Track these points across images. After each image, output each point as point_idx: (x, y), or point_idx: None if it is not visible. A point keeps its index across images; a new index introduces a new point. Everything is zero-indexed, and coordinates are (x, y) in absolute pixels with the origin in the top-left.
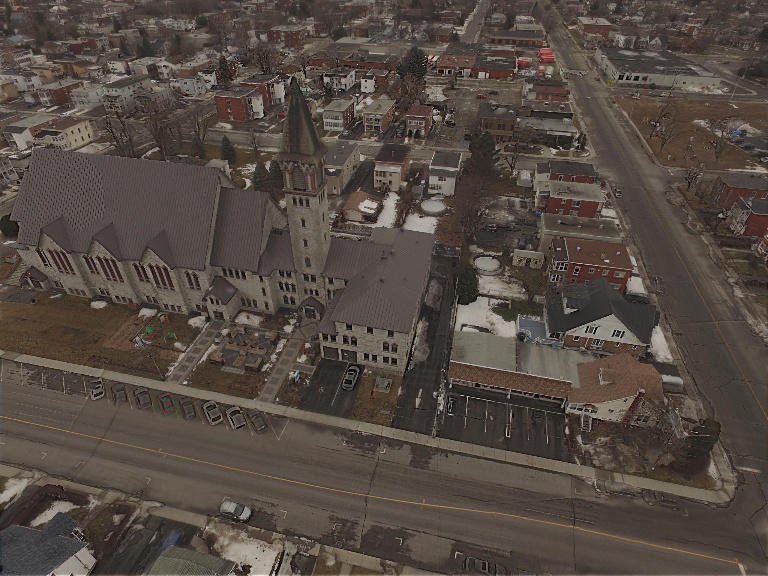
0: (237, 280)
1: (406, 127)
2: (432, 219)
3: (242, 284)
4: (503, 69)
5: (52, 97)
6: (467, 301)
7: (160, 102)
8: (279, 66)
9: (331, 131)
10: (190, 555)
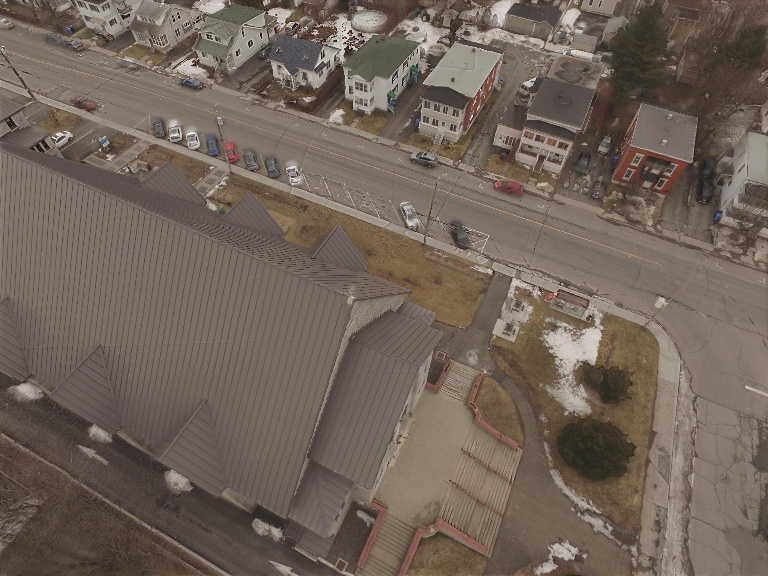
0: None
1: None
2: None
3: None
4: None
5: None
6: None
7: None
8: None
9: None
10: (215, 51)
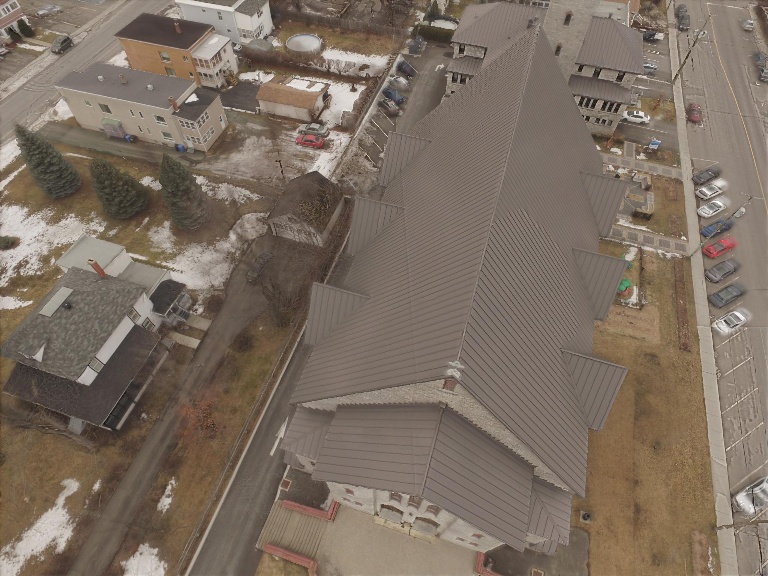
0: None
1: None
2: (330, 52)
3: None
4: None
5: None
6: None
7: None
8: None
9: None
10: None
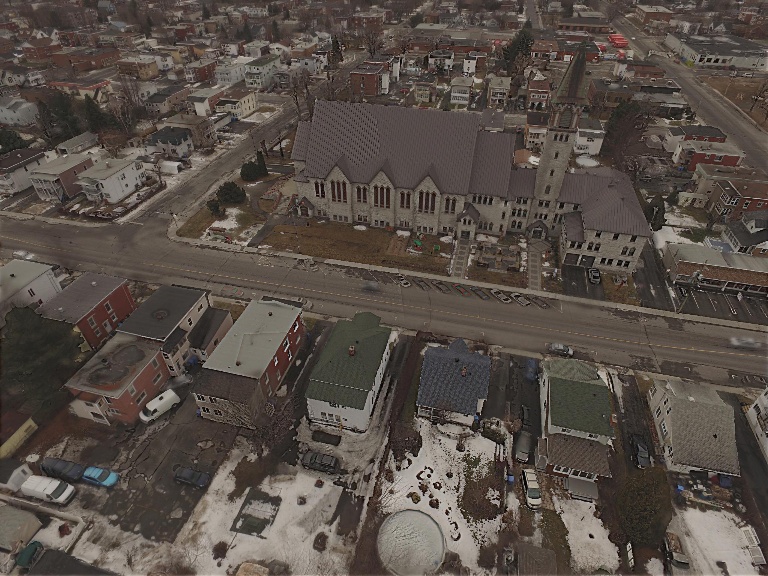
0: (483, 206)
1: (528, 100)
2: None
3: (486, 209)
4: (588, 52)
5: (195, 74)
6: (657, 228)
7: (298, 79)
8: (380, 49)
9: (458, 104)
10: None
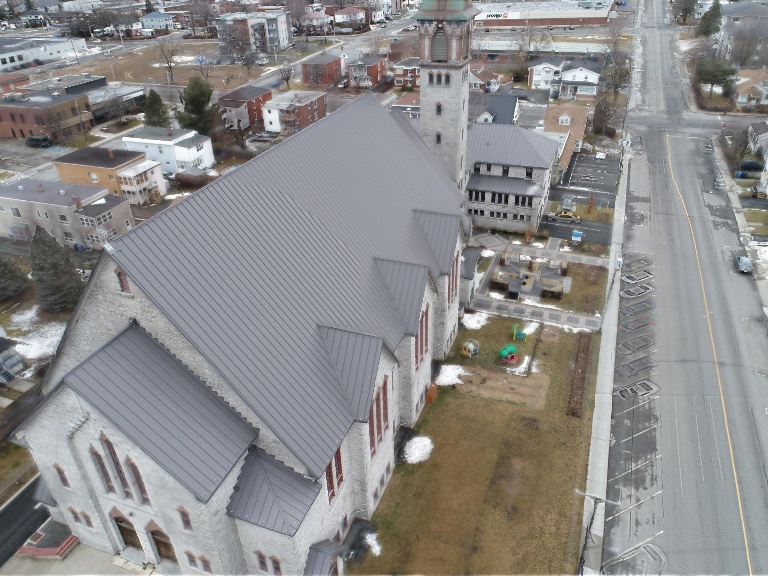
0: None
1: None
2: None
3: None
4: None
5: None
6: None
7: None
8: None
9: None
10: None
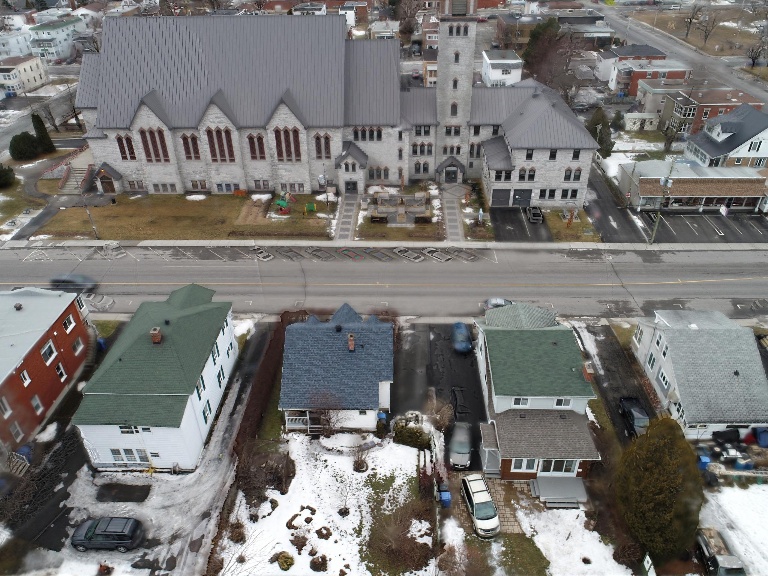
0: (370, 143)
1: (424, 44)
2: None
3: (375, 148)
4: None
5: None
6: (605, 154)
7: None
8: (228, 8)
9: None
10: None
